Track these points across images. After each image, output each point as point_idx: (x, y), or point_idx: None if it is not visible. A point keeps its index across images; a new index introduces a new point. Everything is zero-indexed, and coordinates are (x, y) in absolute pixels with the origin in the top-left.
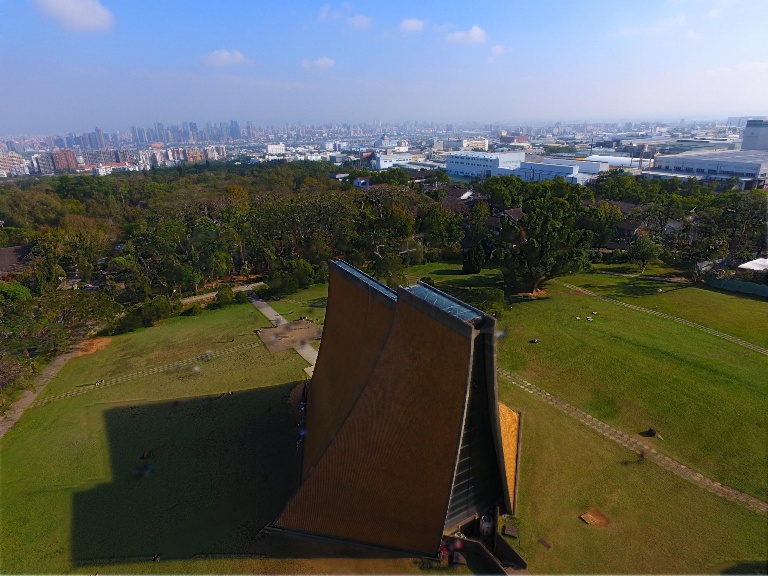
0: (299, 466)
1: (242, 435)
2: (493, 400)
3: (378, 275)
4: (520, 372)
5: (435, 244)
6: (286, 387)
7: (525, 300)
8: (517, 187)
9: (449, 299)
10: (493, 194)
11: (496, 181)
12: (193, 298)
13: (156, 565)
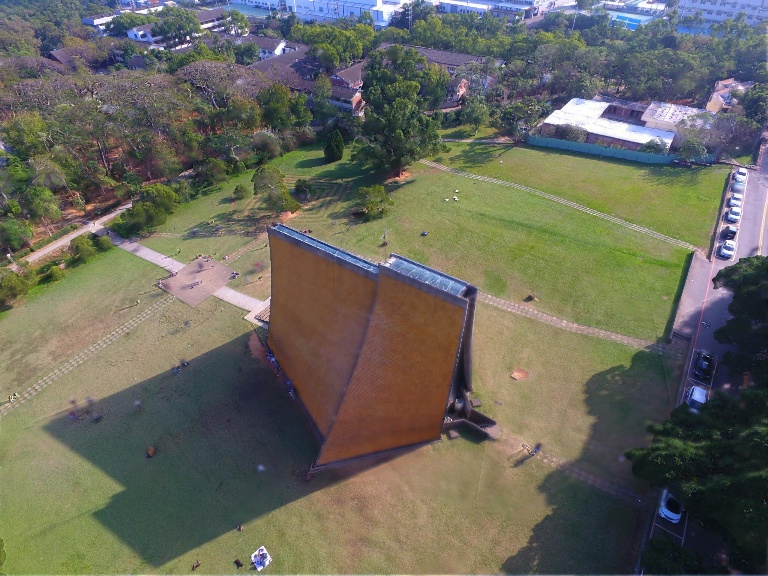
0: (304, 412)
1: (232, 402)
2: (470, 335)
3: (261, 192)
4: None
5: (285, 130)
6: (240, 342)
7: (397, 187)
8: (342, 43)
9: (430, 271)
10: (320, 54)
11: (317, 36)
12: (33, 255)
13: (244, 533)
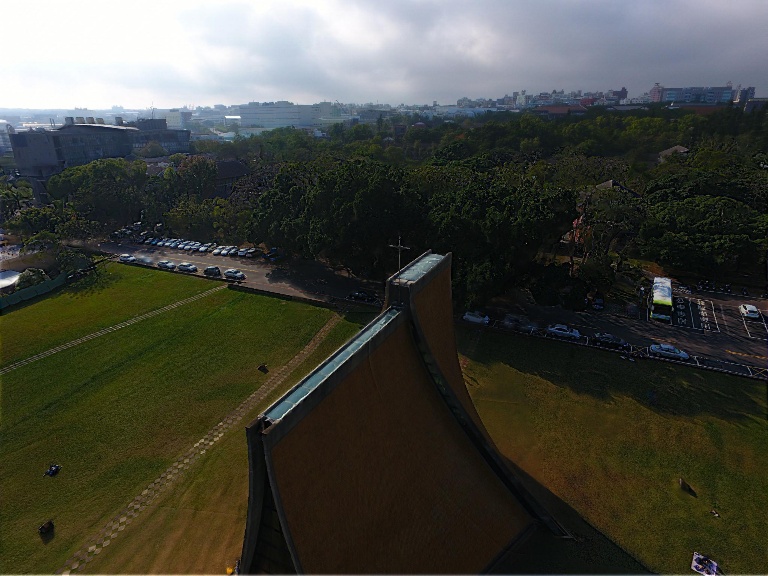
0: (494, 569)
1: None
2: None
3: None
4: (170, 455)
5: None
6: None
7: None
8: None
9: (413, 265)
10: None
11: None
12: None
13: None
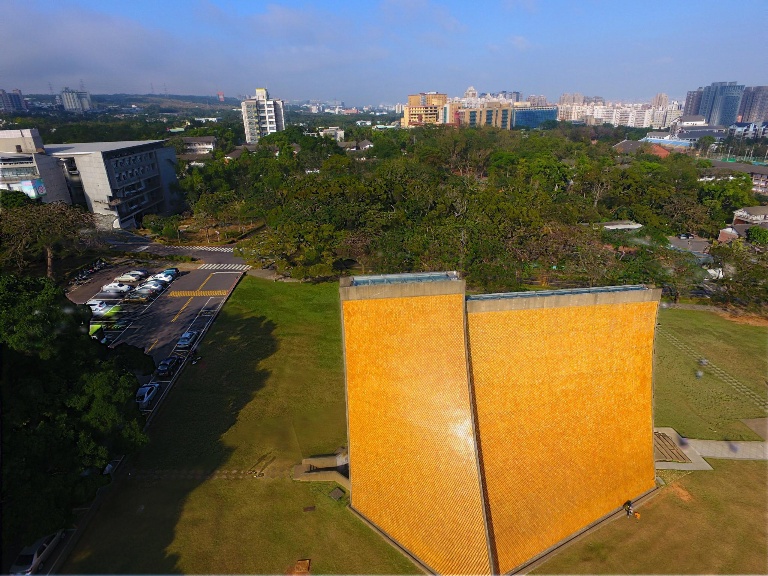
0: None
1: None
2: None
3: None
4: None
5: None
6: None
7: None
8: None
9: None
10: None
11: None
12: None
13: None
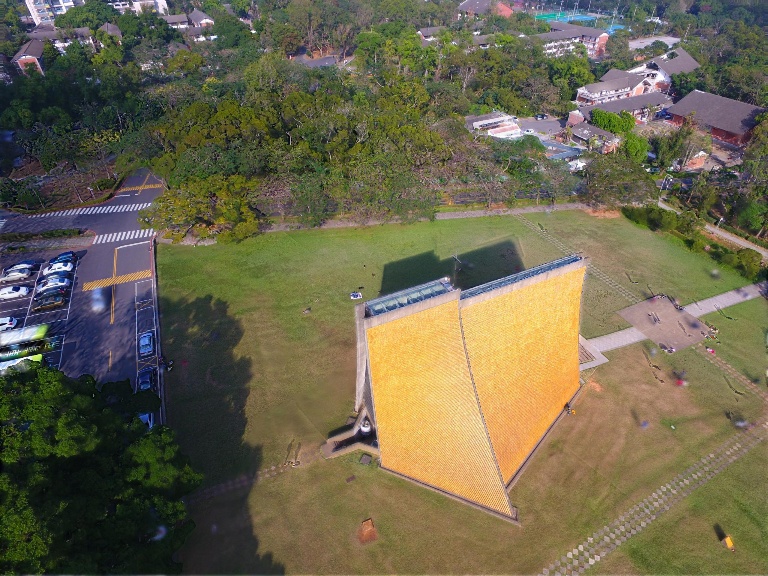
0: None
1: None
2: None
3: None
4: (626, 562)
5: None
6: None
7: None
8: None
9: None
10: None
11: None
12: (739, 240)
13: (375, 293)
